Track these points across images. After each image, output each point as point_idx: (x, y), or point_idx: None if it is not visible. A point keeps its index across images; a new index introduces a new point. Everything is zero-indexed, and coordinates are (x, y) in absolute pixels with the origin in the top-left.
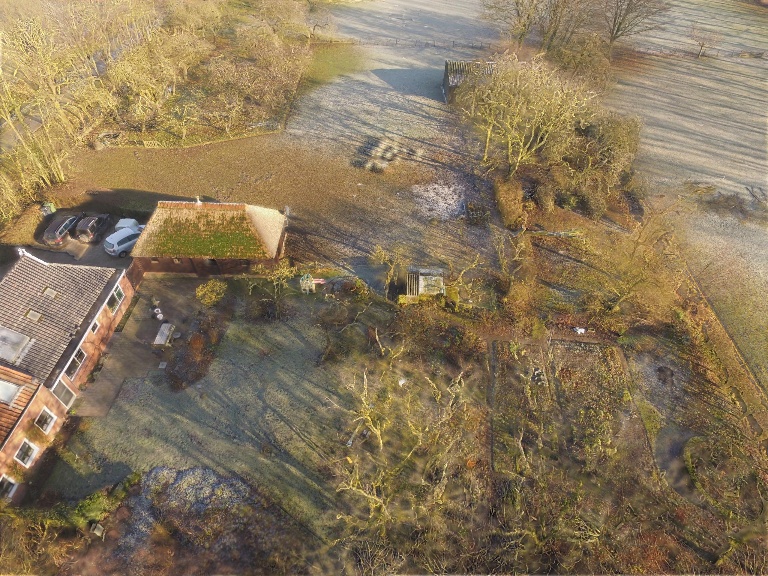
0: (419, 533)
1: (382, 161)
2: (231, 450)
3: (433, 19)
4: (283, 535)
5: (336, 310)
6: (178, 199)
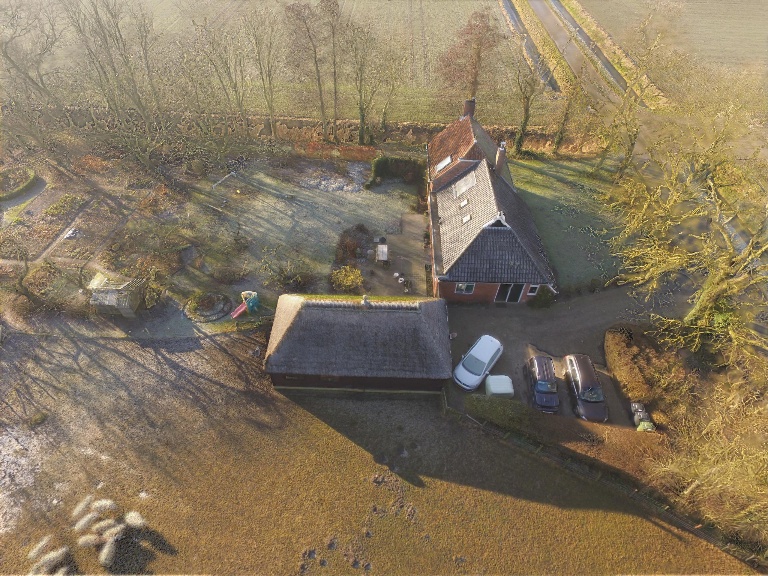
0: (208, 172)
1: None
2: (313, 198)
3: None
4: (281, 172)
5: (225, 270)
6: (465, 476)
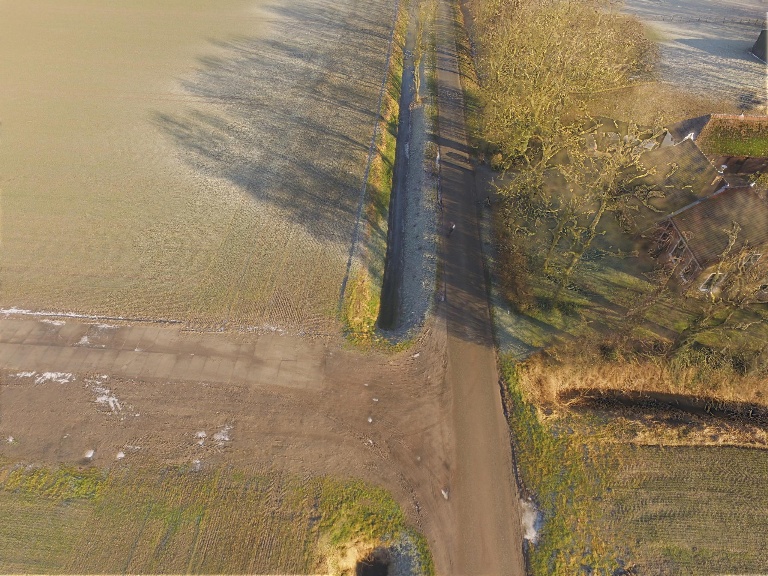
0: None
1: (765, 104)
2: None
3: (678, 1)
4: None
5: None
6: None
